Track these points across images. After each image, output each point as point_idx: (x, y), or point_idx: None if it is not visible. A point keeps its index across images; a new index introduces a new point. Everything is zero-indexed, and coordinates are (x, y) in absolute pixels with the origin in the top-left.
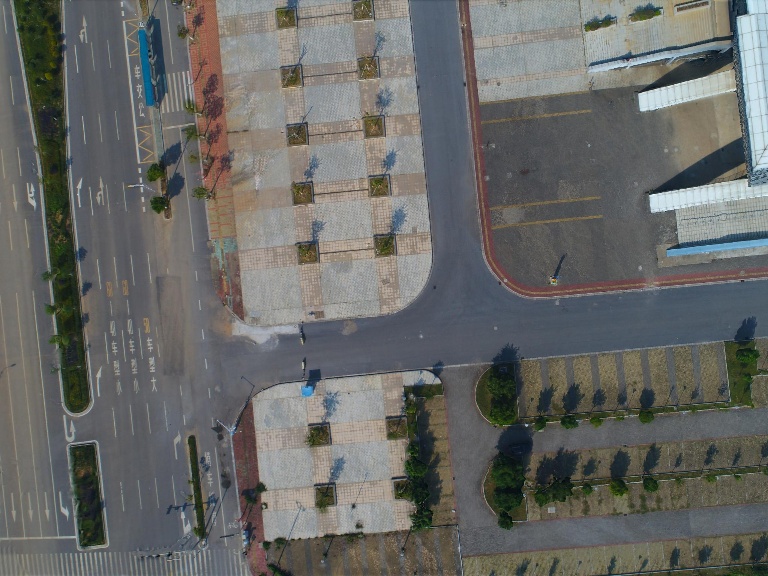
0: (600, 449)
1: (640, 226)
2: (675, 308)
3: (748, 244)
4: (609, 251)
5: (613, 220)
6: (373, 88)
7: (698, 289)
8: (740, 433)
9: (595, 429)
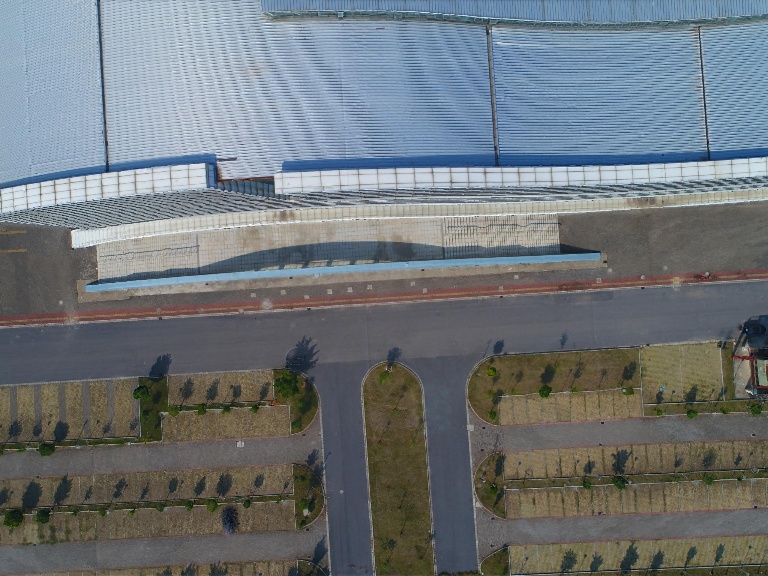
0: (14, 479)
1: (62, 261)
2: (94, 343)
3: (140, 284)
4: (32, 285)
5: (37, 254)
6: None
7: (117, 325)
8: (150, 468)
9: (10, 460)
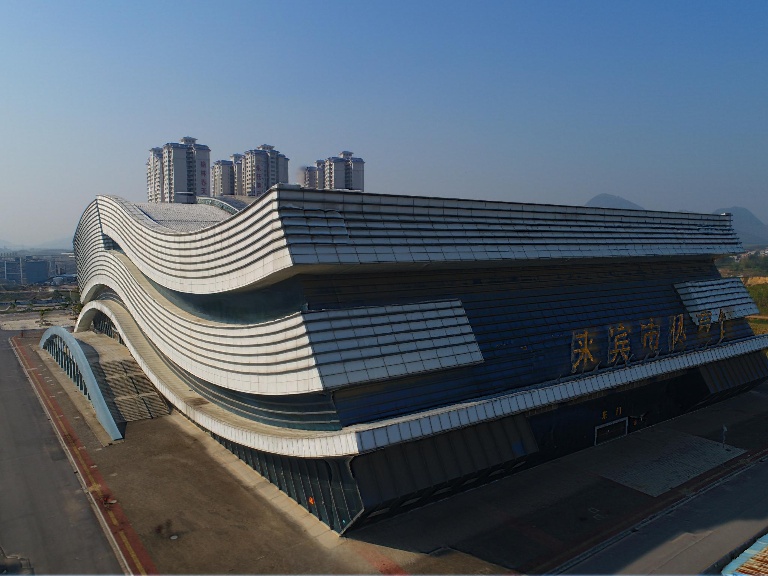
0: None
1: None
2: None
3: None
4: None
5: None
6: None
7: None
8: None
9: None
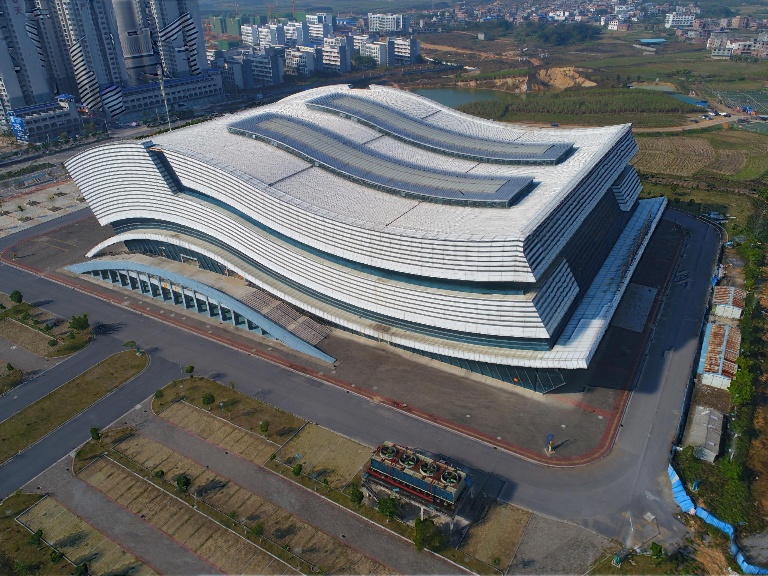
0: None
1: None
2: None
3: (87, 262)
4: (49, 259)
5: None
6: (74, 203)
7: (53, 283)
8: None
9: None
